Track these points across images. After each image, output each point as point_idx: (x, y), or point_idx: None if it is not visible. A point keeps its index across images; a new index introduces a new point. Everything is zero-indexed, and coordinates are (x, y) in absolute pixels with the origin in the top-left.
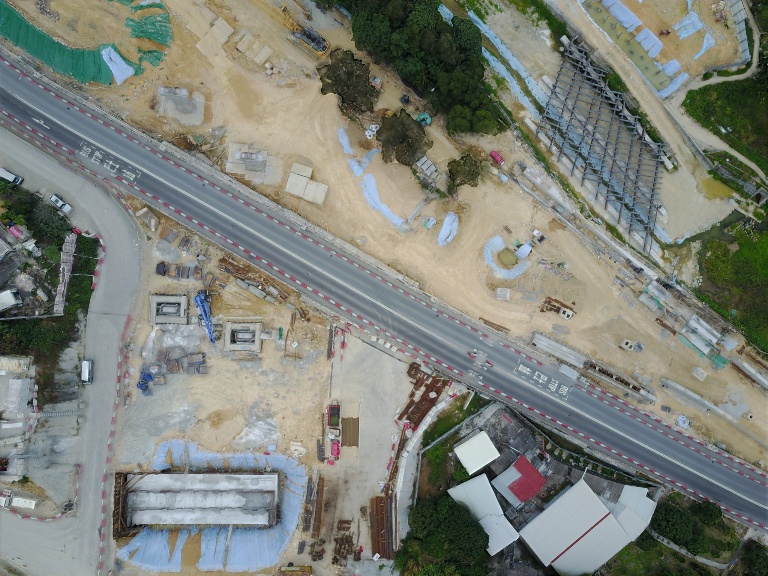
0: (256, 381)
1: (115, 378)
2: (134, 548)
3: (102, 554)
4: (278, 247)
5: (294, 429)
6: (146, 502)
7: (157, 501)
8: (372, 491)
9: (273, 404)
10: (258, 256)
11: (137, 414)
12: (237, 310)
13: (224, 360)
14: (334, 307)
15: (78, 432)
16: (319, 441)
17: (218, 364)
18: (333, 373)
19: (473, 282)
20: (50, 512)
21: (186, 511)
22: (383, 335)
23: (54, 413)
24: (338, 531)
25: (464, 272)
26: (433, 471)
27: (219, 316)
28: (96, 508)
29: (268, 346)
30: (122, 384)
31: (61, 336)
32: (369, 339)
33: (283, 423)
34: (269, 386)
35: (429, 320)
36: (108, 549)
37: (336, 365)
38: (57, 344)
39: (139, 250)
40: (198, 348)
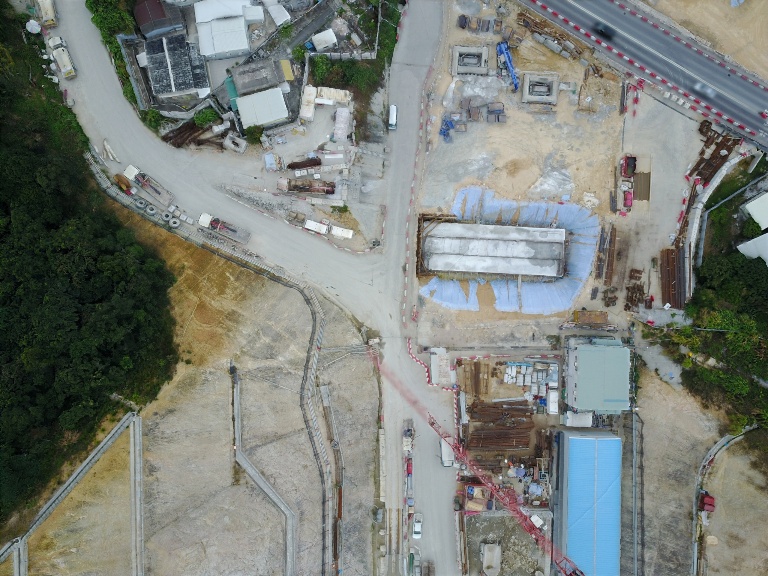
0: (550, 133)
1: (417, 126)
2: (433, 288)
3: (407, 289)
4: (573, 4)
5: (588, 180)
6: (441, 249)
7: (451, 248)
8: (662, 244)
9: (567, 156)
10: (554, 11)
11: (438, 160)
12: (533, 64)
13: (520, 112)
14: (627, 64)
15: (383, 175)
16: (612, 193)
17: (515, 115)
18: (625, 128)
19: (763, 45)
20: (360, 246)
21: (478, 259)
22: (675, 93)
23: (367, 151)
24: (630, 280)
25: (754, 34)
26: (716, 233)
27: (515, 70)
28: (400, 247)
29: (562, 100)
30: (424, 131)
31: (374, 78)
32: (661, 96)
33: (577, 174)
34: (563, 139)
35: (721, 79)
36: (412, 285)
37: (628, 121)
38: (370, 85)
39: (440, 4)
40: (496, 99)
